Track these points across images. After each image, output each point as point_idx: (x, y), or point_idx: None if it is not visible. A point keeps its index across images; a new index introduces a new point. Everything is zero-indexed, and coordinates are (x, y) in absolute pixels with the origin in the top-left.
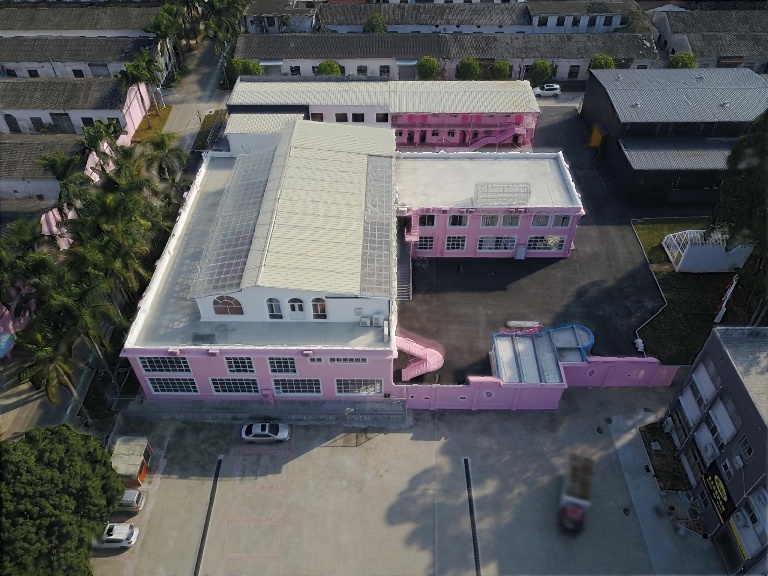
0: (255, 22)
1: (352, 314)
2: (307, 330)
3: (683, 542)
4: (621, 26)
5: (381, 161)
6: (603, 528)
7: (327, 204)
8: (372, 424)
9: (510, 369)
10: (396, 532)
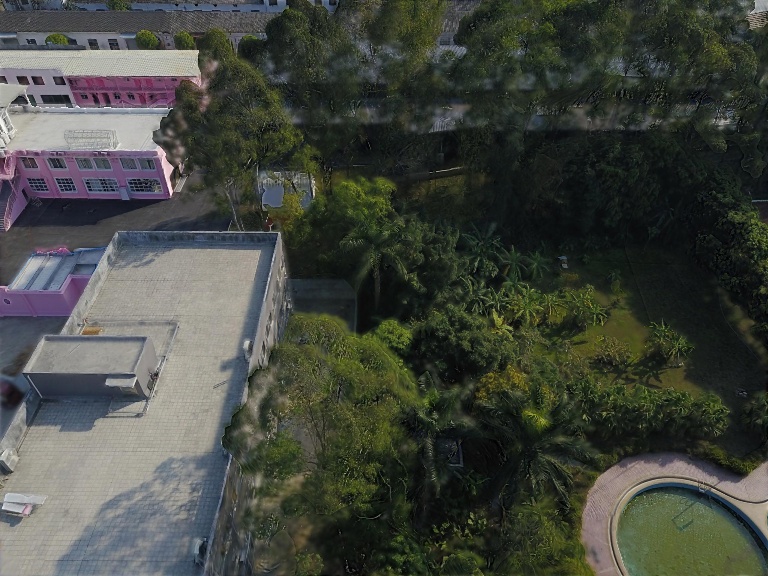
0: None
1: None
2: None
3: None
4: None
5: None
6: None
7: None
8: None
9: (25, 280)
10: None
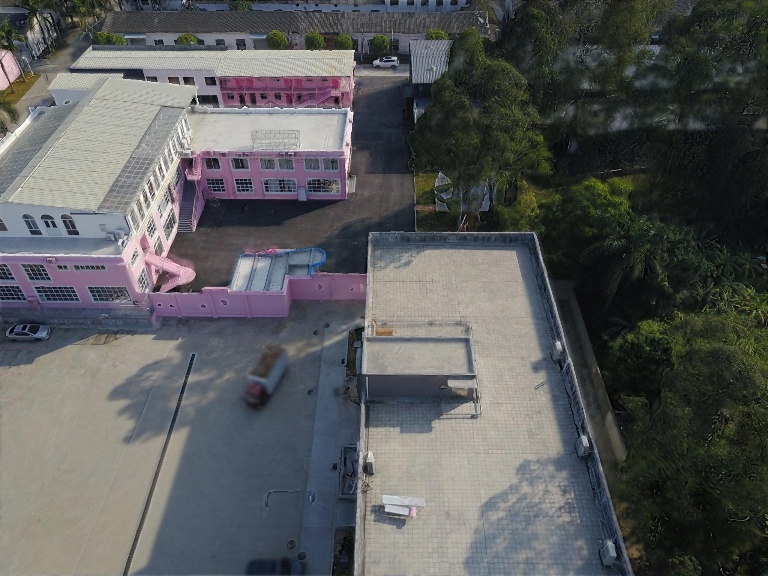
0: (130, 1)
1: (99, 230)
2: (60, 243)
3: (347, 414)
4: (467, 5)
5: (172, 111)
6: (285, 404)
7: (103, 143)
8: (123, 327)
9: (242, 281)
10: (111, 406)
